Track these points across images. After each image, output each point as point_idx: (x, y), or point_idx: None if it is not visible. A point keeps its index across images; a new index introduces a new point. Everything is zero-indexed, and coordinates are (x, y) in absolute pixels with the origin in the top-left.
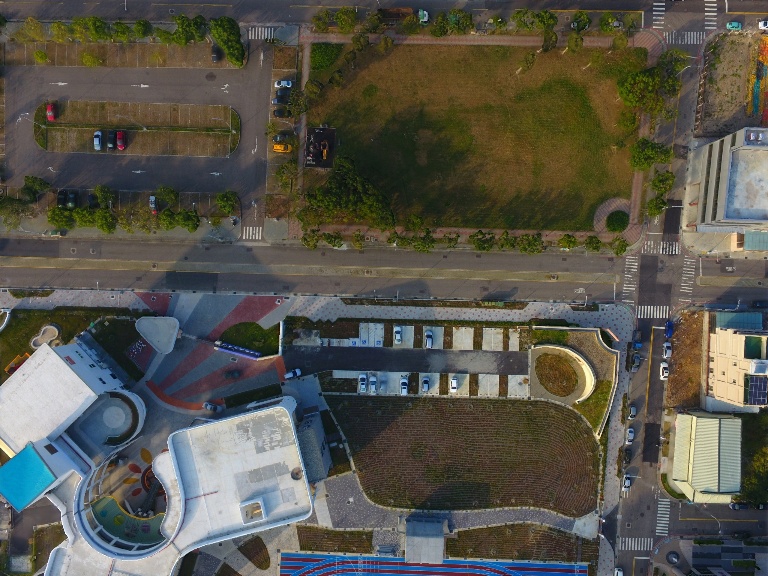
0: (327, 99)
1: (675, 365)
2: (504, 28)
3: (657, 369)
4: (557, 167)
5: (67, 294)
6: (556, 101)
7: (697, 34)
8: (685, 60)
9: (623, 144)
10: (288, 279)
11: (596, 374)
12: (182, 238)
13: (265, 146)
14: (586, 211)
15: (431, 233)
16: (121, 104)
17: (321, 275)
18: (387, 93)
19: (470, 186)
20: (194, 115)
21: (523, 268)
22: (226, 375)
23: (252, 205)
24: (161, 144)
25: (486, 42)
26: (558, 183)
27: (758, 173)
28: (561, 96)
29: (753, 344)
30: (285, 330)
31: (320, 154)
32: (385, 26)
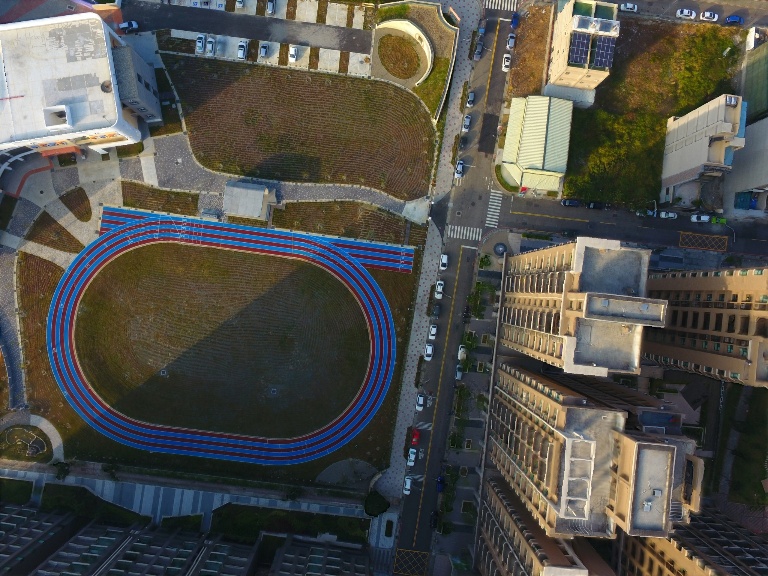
0: None
1: (519, 58)
2: None
3: (500, 60)
4: None
5: None
6: None
7: None
8: None
9: None
10: None
11: (434, 49)
12: None
13: None
14: None
15: None
16: None
17: None
18: None
19: None
20: None
21: None
22: None
23: None
24: None
25: None
26: None
27: None
28: None
29: (584, 11)
30: None
31: None
32: None
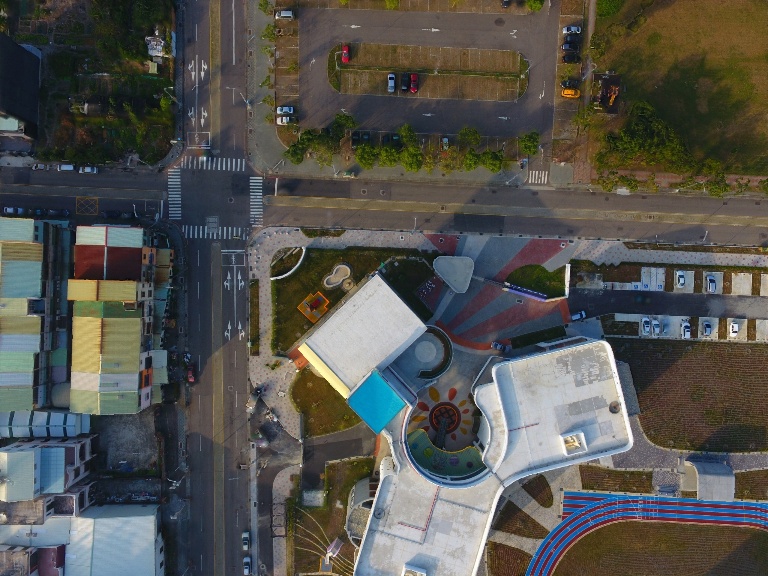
0: (613, 46)
1: None
2: None
3: None
4: None
5: (358, 234)
6: None
7: None
8: None
9: None
10: (573, 223)
11: None
12: (470, 181)
13: (552, 91)
14: None
15: (725, 177)
16: (412, 48)
17: (605, 219)
18: (671, 41)
19: (751, 134)
20: (483, 60)
21: None
22: (512, 316)
23: (539, 149)
24: (451, 88)
25: None
26: None
27: None
28: None
29: None
30: None
31: (607, 100)
32: None
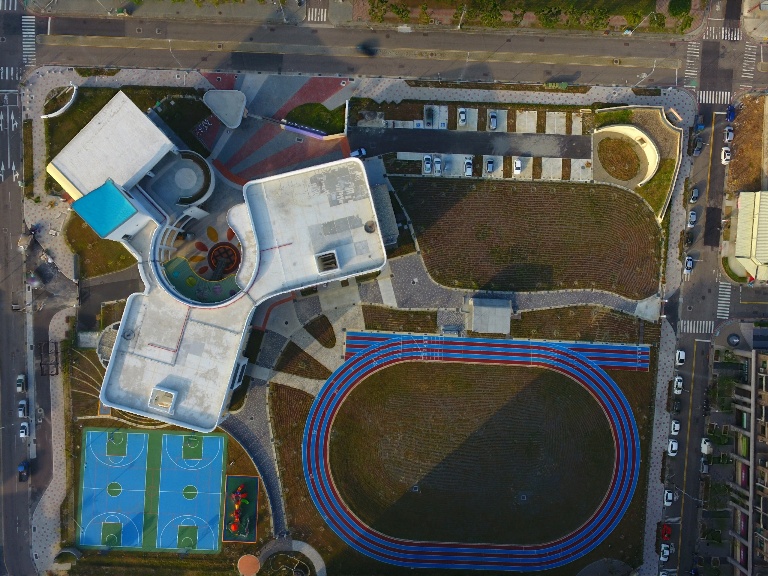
0: None
1: (736, 150)
2: None
3: (718, 154)
4: None
5: (133, 73)
6: None
7: None
8: None
9: None
10: (353, 61)
11: (660, 152)
12: (247, 19)
13: None
14: None
15: (498, 6)
16: None
17: (385, 57)
18: None
19: None
20: None
21: (586, 52)
22: (291, 155)
23: None
24: None
25: None
26: None
27: None
28: None
29: None
30: (350, 112)
31: None
32: None
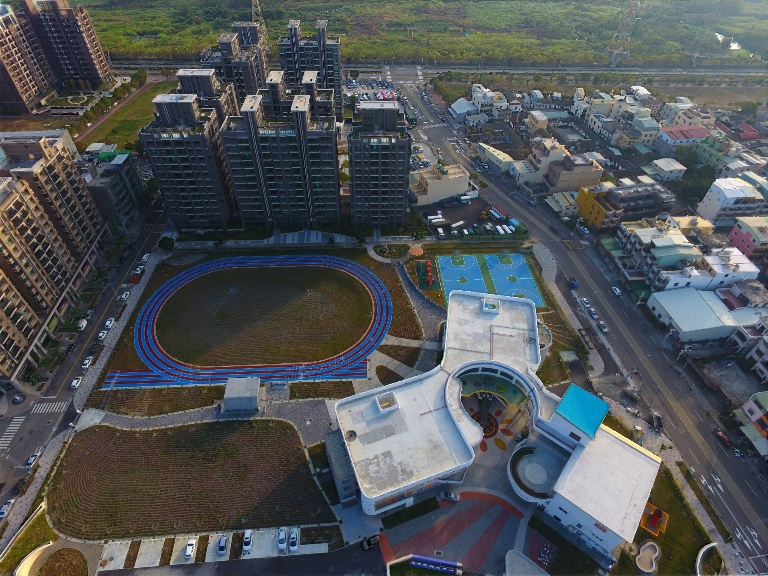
0: None
1: None
2: None
3: None
4: None
5: None
6: None
7: None
8: None
9: None
10: None
11: None
12: None
13: None
14: None
15: None
16: None
17: None
18: None
19: None
20: None
21: None
22: (443, 533)
23: None
24: None
25: None
26: None
27: None
28: None
29: None
30: None
31: None
32: None
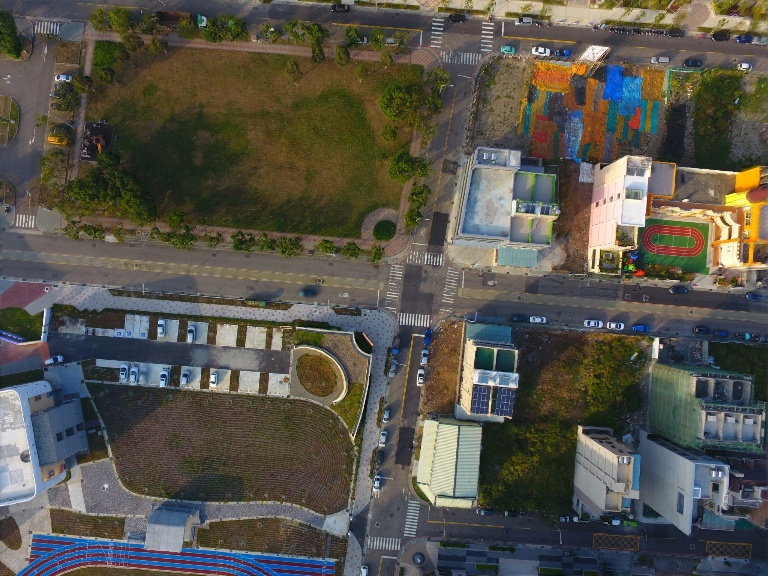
0: (107, 95)
1: (433, 372)
2: (286, 38)
3: (415, 375)
4: (329, 175)
5: None
6: (332, 111)
7: (473, 55)
8: (449, 79)
9: (384, 156)
10: (58, 268)
11: (348, 376)
12: None
13: (43, 137)
14: (354, 219)
15: (191, 231)
16: None
17: (91, 266)
18: (167, 93)
19: (243, 188)
20: None
21: (290, 270)
22: None
23: (26, 194)
24: None
25: (267, 50)
26: (329, 190)
27: (499, 191)
28: (337, 107)
29: (486, 355)
30: (52, 317)
31: (96, 148)
32: (169, 28)
